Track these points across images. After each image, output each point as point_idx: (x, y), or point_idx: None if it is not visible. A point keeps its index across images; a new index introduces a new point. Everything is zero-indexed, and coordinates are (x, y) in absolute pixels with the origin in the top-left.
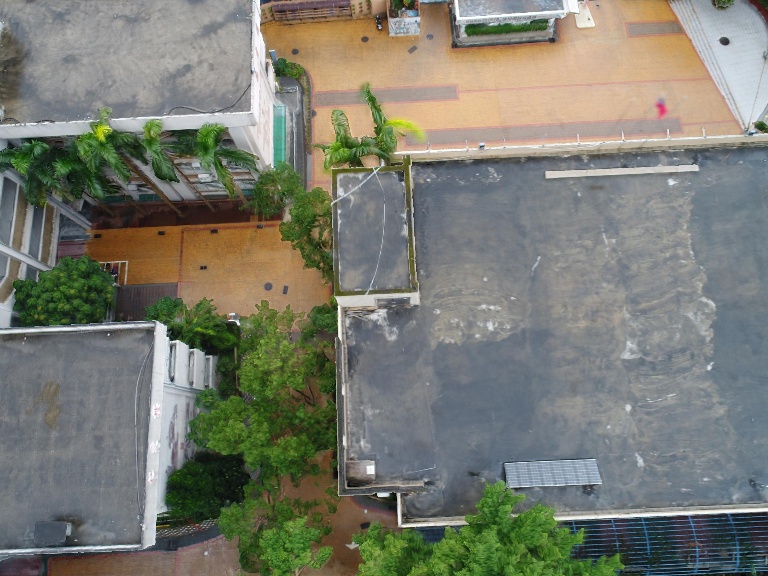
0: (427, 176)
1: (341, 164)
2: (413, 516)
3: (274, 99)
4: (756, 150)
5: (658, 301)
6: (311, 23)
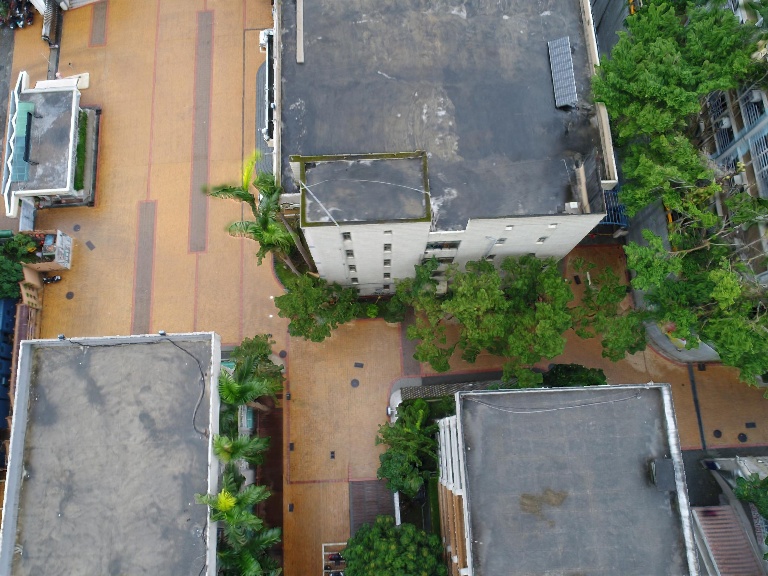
0: None
1: None
2: (604, 177)
3: None
4: None
5: None
6: None
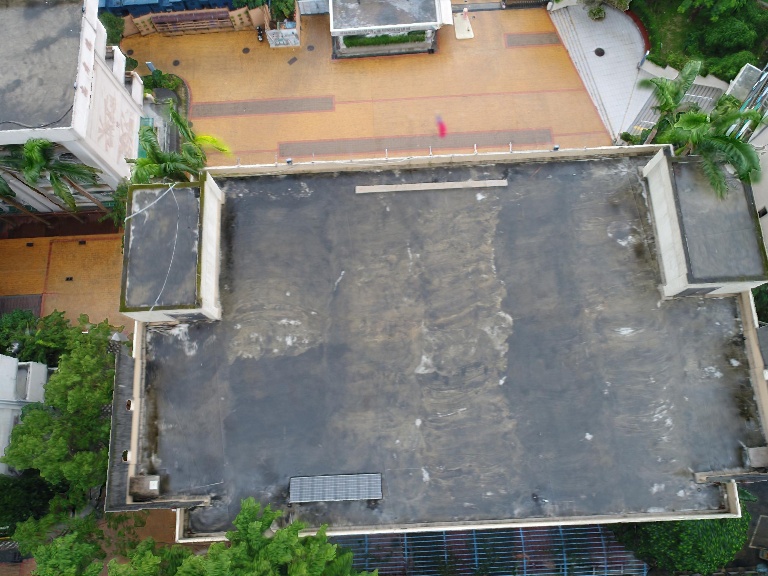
0: (240, 191)
1: (157, 179)
2: (197, 531)
3: (141, 111)
4: (566, 165)
5: (456, 316)
6: (194, 34)
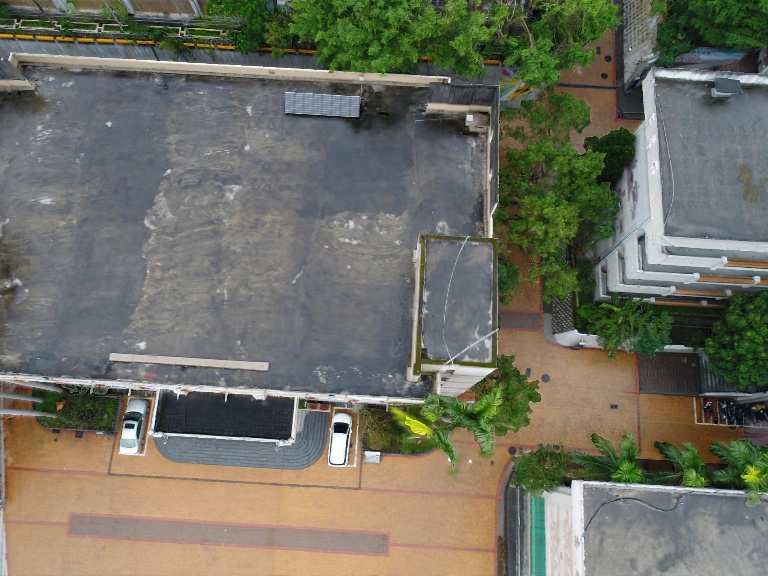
0: (391, 381)
1: None
2: None
3: None
4: (43, 371)
5: (194, 230)
6: None
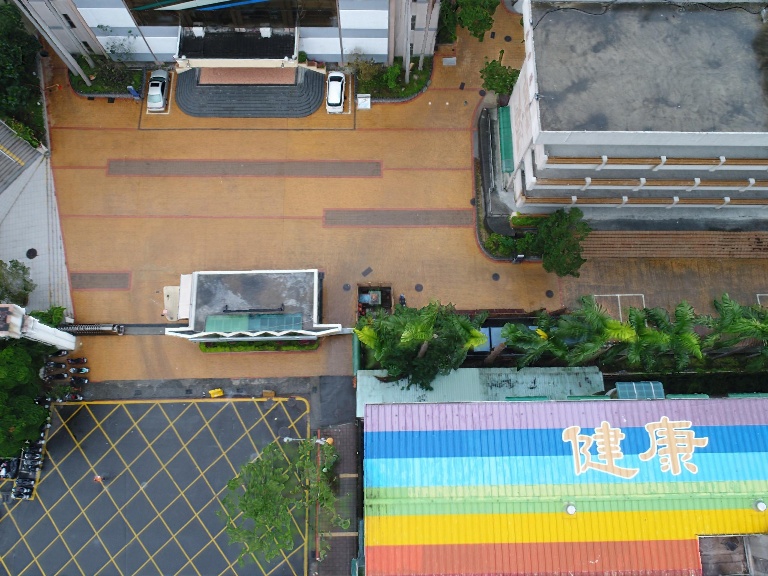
0: None
1: None
2: None
3: None
4: None
5: None
6: None
